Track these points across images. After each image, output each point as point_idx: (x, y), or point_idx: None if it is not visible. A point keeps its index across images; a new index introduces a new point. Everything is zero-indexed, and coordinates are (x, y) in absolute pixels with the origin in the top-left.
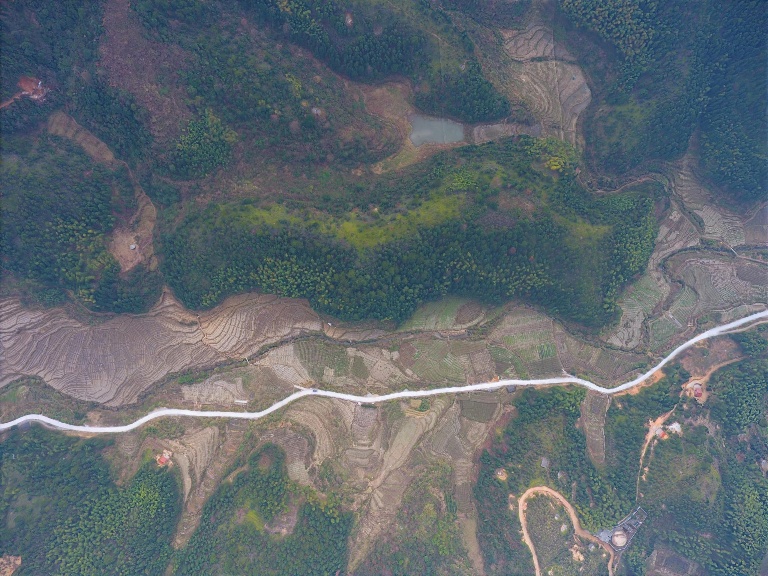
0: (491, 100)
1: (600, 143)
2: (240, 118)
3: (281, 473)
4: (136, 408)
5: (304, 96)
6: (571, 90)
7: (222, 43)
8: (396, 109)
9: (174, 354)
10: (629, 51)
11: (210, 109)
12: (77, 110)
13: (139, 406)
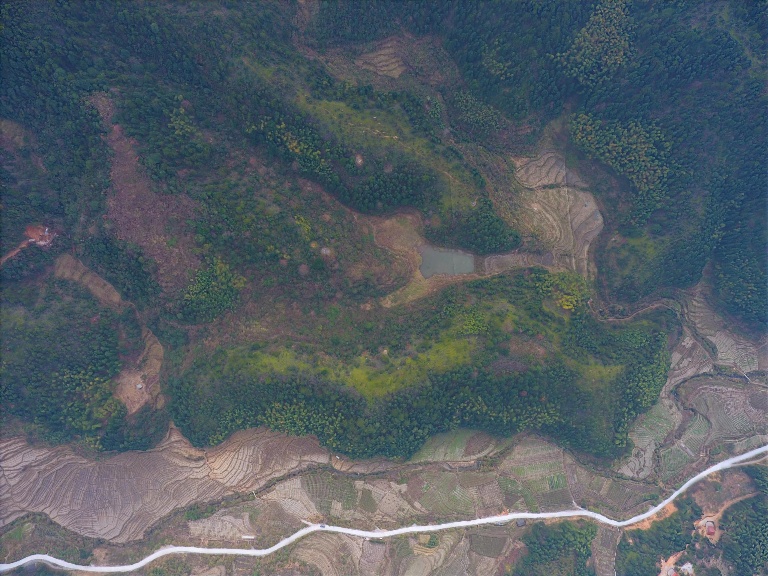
0: (502, 236)
1: (612, 274)
2: (248, 261)
3: None
4: (142, 544)
5: (313, 238)
6: (583, 217)
7: (231, 188)
8: (406, 240)
9: (181, 489)
10: (643, 186)
11: (218, 256)
12: (84, 255)
13: (145, 542)
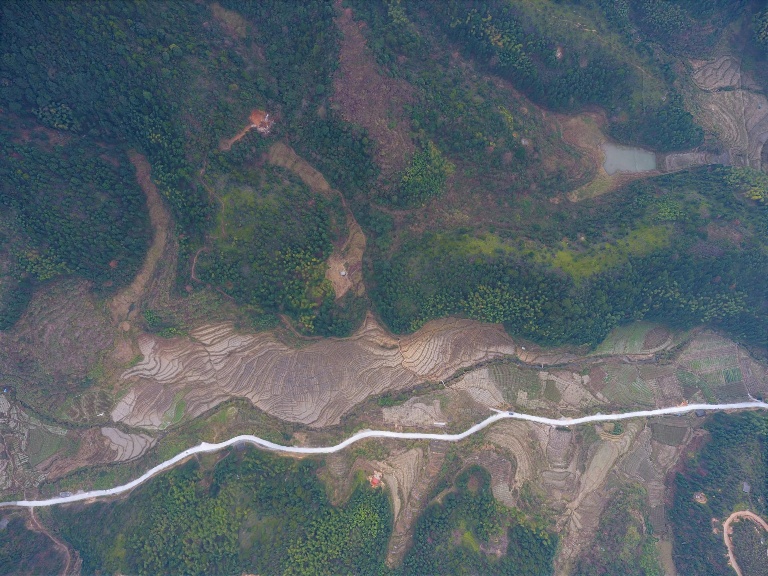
0: (690, 131)
1: None
2: (454, 149)
3: (490, 495)
4: (339, 429)
5: (516, 128)
6: (757, 119)
7: (441, 77)
8: (590, 138)
9: (374, 377)
10: None
11: (431, 141)
12: (300, 142)
13: (341, 427)
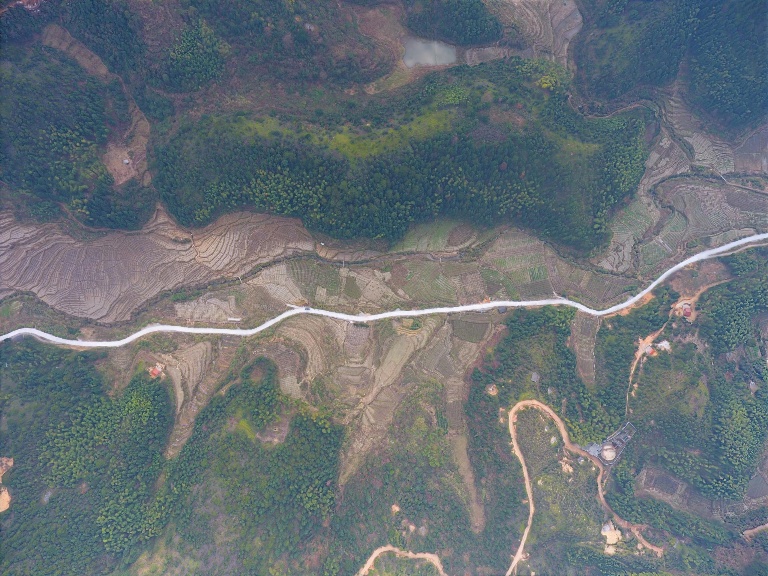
0: (483, 19)
1: (591, 66)
2: (233, 32)
3: (273, 385)
4: (129, 325)
5: (297, 11)
6: (563, 16)
7: None
8: (389, 31)
9: (167, 272)
10: None
11: (203, 20)
12: (71, 21)
13: (132, 323)
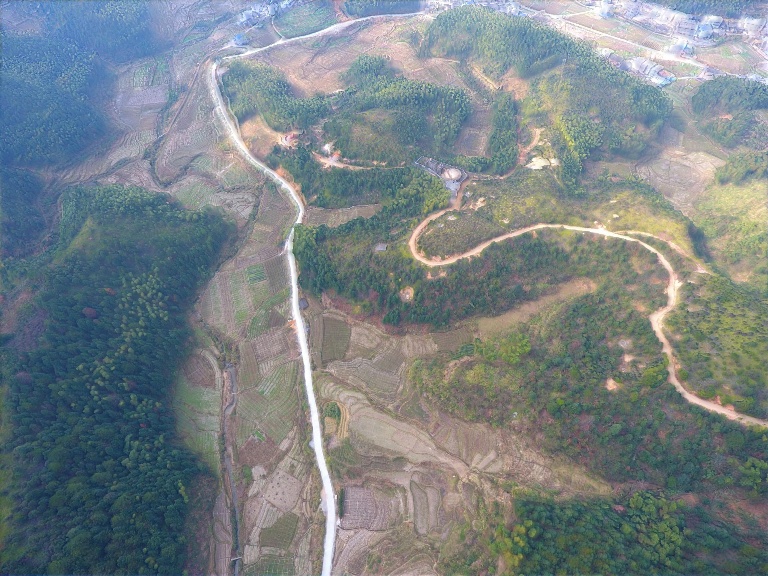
0: None
1: None
2: None
3: None
4: None
5: None
6: None
7: None
8: None
9: None
10: None
11: None
12: None
13: None
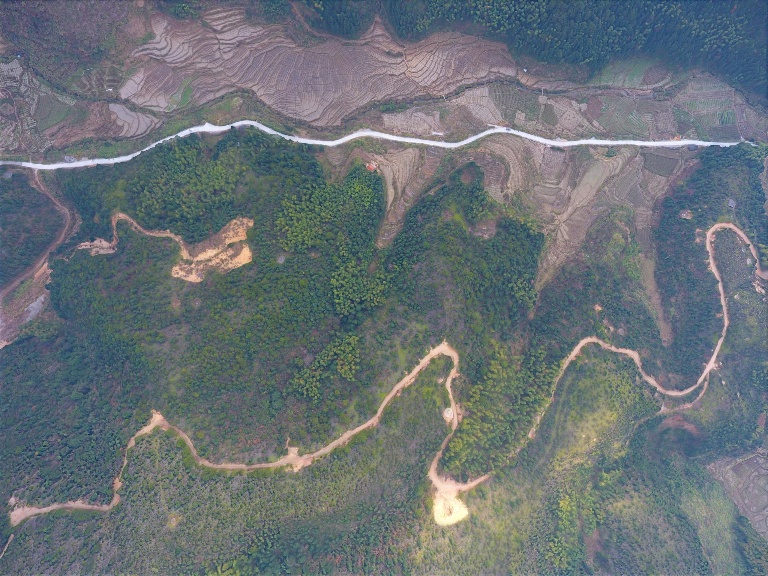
0: None
1: None
2: None
3: None
4: (339, 130)
5: None
6: None
7: None
8: None
9: (378, 83)
10: None
11: None
12: None
13: (342, 129)
